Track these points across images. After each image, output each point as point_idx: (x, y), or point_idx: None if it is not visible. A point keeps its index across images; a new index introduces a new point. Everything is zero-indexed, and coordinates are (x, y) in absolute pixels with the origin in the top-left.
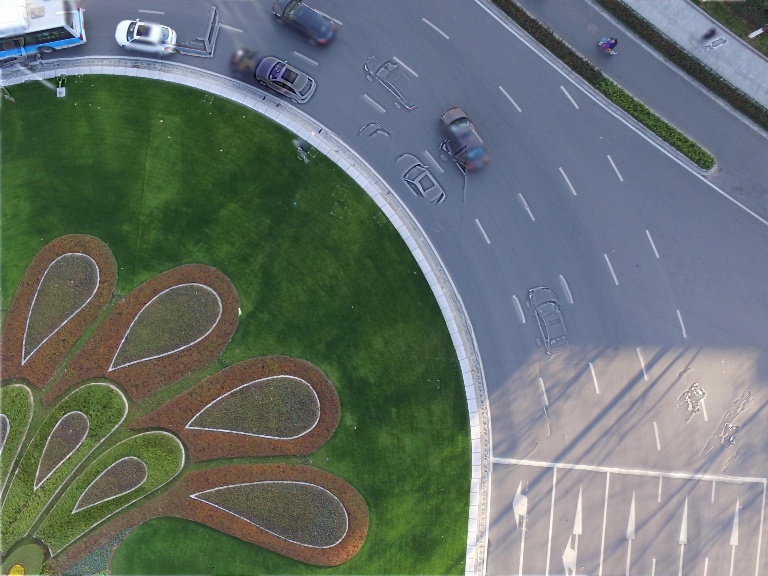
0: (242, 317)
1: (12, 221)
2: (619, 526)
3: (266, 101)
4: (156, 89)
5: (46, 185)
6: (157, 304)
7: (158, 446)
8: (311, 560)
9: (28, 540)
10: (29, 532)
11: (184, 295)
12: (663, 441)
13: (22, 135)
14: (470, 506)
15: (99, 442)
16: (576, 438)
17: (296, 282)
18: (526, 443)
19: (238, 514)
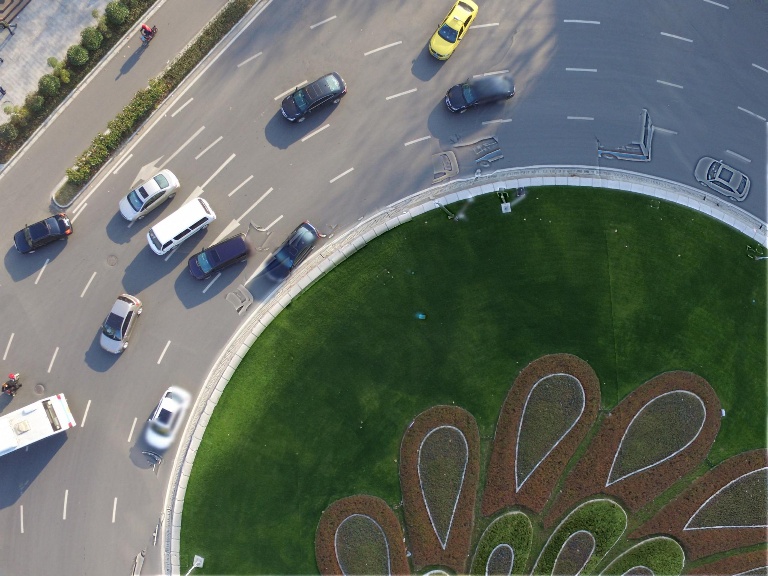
0: (723, 417)
1: (482, 347)
2: None
3: (707, 201)
4: (602, 197)
5: (512, 306)
6: (646, 415)
7: (663, 552)
8: None
9: None
10: None
11: (672, 403)
12: None
13: (475, 256)
14: None
15: (603, 556)
16: None
17: (766, 377)
18: None
19: None
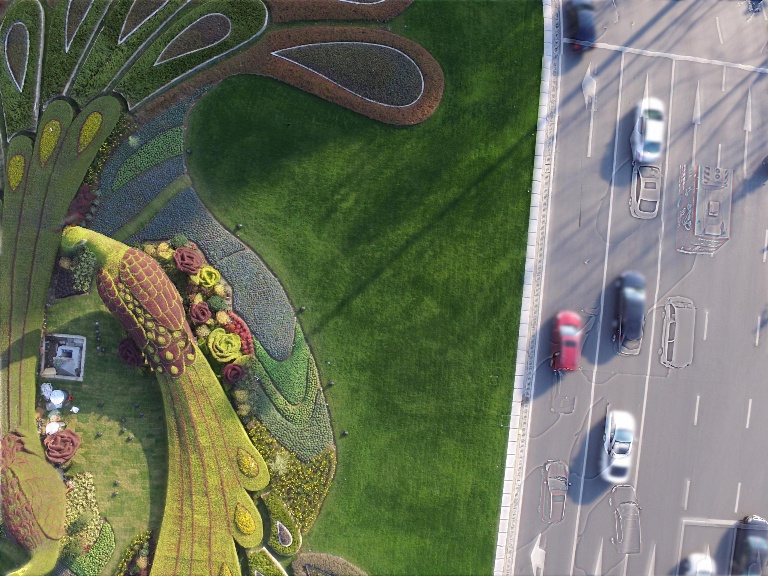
0: None
1: None
2: (685, 113)
3: None
4: None
5: None
6: None
7: (243, 3)
8: (386, 117)
9: None
10: (108, 88)
11: None
12: (726, 36)
13: None
14: (541, 81)
15: (185, 2)
16: (643, 28)
17: None
18: (595, 28)
19: (317, 70)
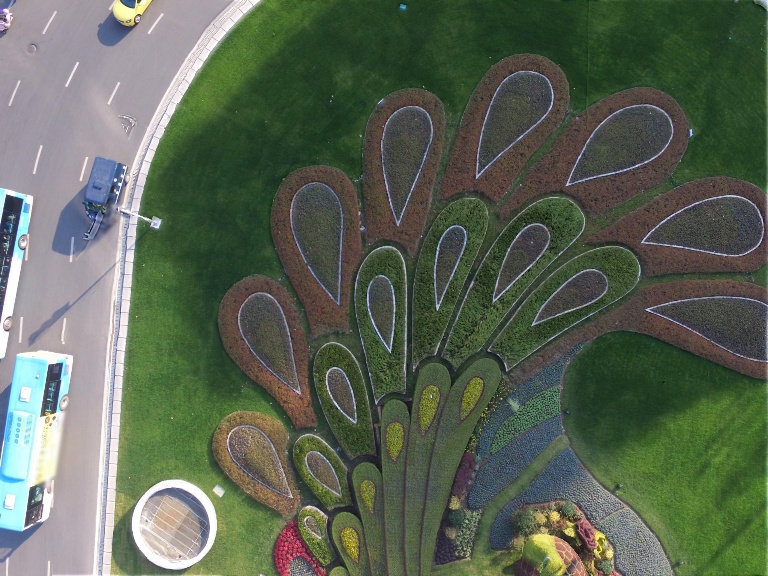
0: (690, 139)
1: (457, 39)
2: None
3: None
4: None
5: (491, 6)
6: (613, 122)
7: (618, 259)
8: (757, 373)
9: (480, 355)
10: (482, 347)
11: (639, 115)
12: None
13: None
14: None
15: (557, 255)
16: None
17: (737, 109)
18: None
19: (692, 327)
